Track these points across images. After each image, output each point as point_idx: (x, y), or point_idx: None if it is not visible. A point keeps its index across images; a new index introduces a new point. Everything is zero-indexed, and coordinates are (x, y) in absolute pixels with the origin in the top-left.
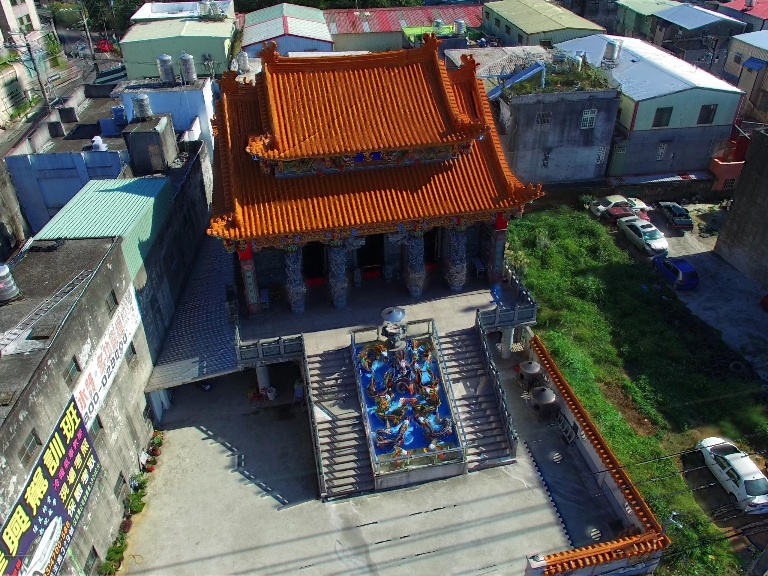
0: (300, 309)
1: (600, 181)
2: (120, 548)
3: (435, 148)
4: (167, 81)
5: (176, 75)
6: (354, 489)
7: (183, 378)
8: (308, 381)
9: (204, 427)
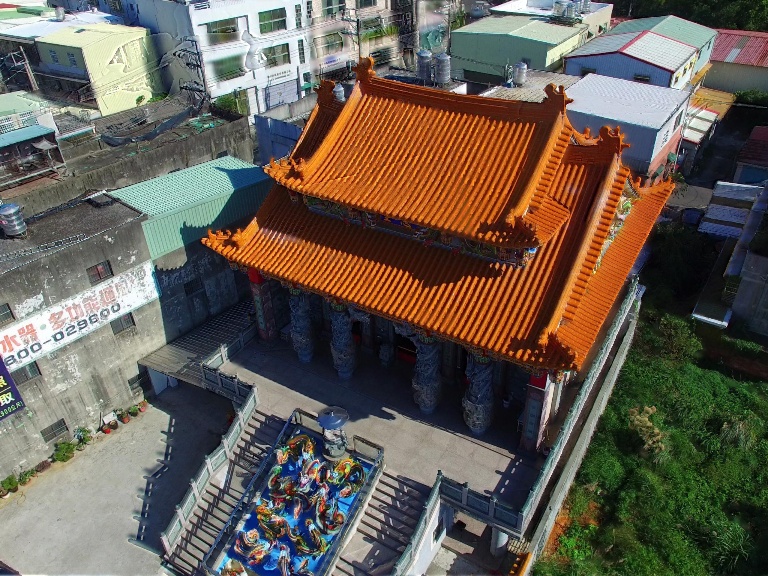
0: (303, 358)
1: None
2: (14, 481)
3: None
4: (420, 78)
5: (493, 74)
6: (191, 574)
7: (166, 367)
8: (222, 435)
9: (175, 421)
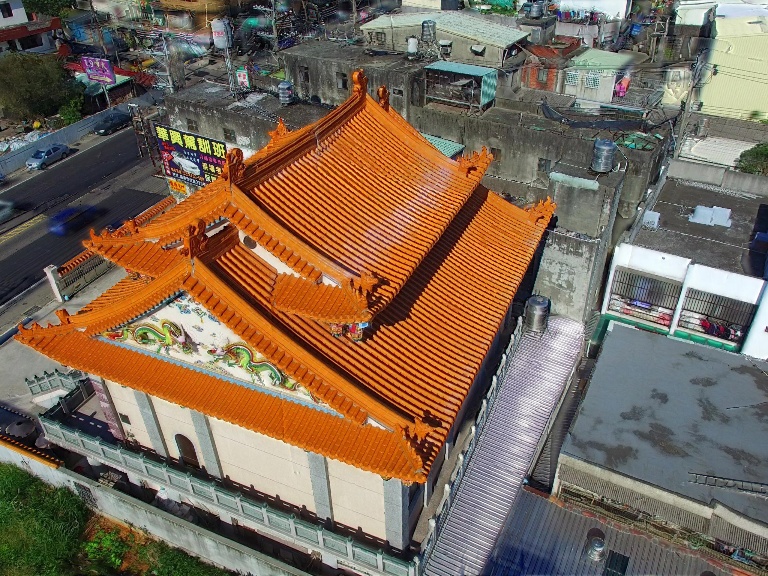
0: None
1: None
2: None
3: None
4: None
5: None
6: None
7: None
8: None
9: None
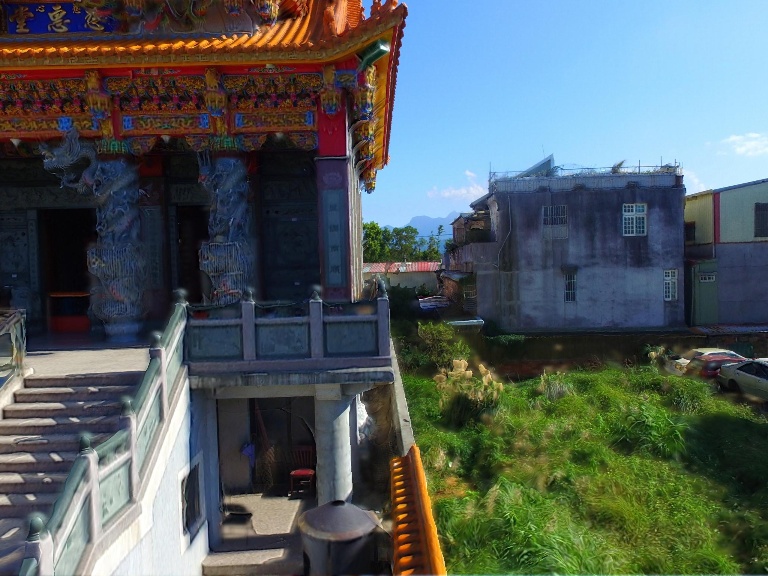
0: None
1: (677, 330)
2: None
3: (195, 1)
4: None
5: None
6: None
7: None
8: None
9: None
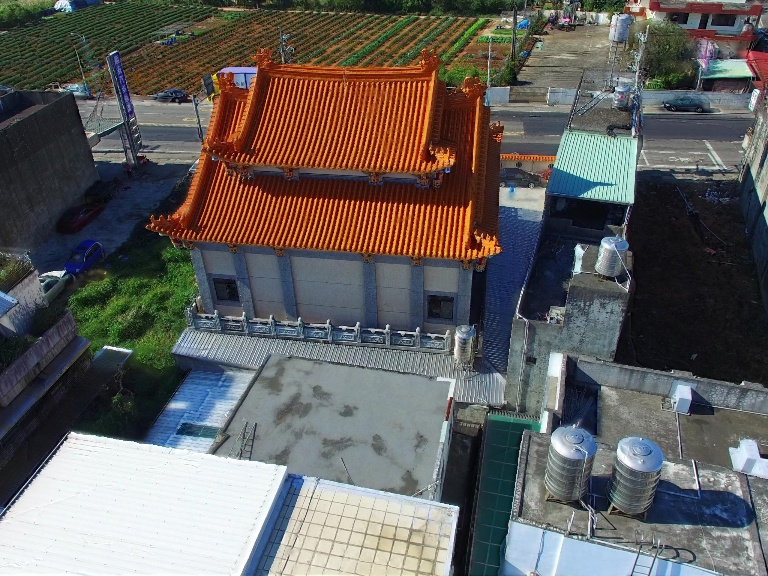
0: None
1: None
2: None
3: None
4: None
5: None
6: None
7: (529, 210)
8: None
9: None
